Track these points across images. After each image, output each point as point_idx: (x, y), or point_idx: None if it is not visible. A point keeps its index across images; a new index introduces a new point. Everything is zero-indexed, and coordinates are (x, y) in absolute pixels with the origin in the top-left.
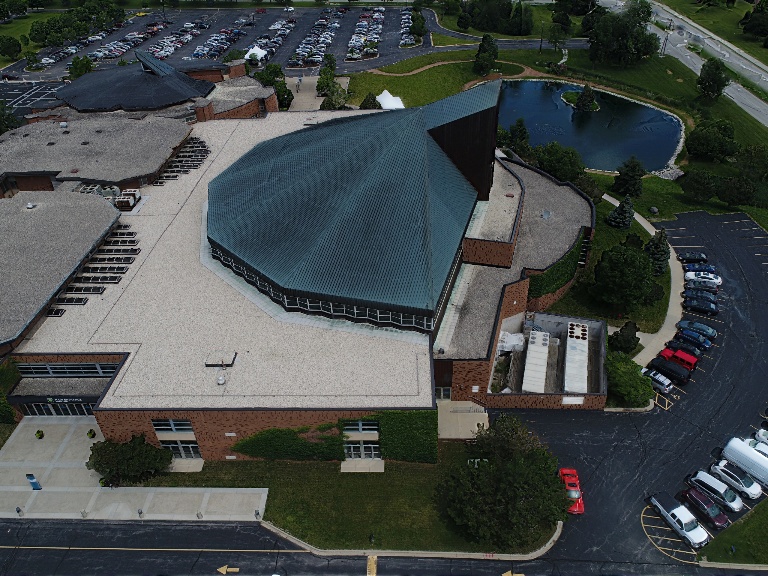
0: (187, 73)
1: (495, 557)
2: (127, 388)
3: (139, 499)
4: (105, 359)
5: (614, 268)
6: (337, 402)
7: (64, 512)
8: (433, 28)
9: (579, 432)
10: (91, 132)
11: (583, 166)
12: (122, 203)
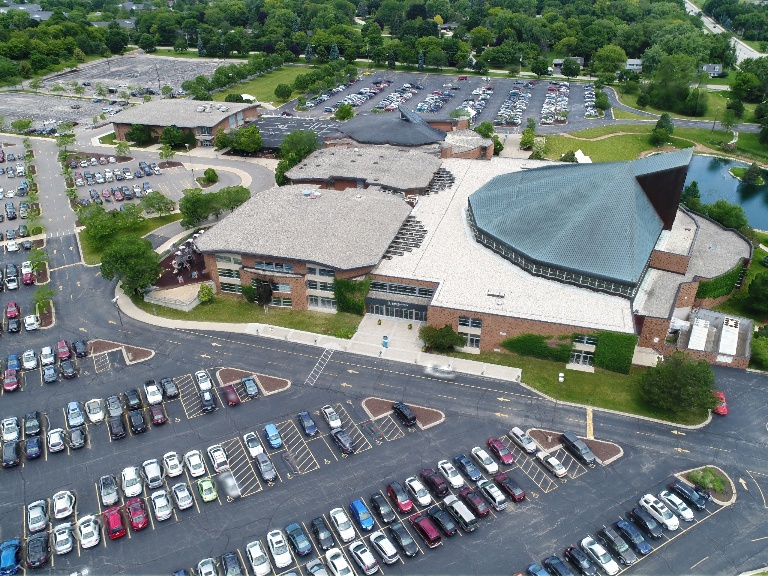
0: (429, 123)
1: (667, 423)
2: (444, 299)
3: (445, 361)
4: (424, 284)
5: (765, 284)
6: (573, 323)
7: (404, 359)
8: (613, 104)
9: (727, 378)
10: (376, 157)
11: (746, 220)
12: (409, 203)
